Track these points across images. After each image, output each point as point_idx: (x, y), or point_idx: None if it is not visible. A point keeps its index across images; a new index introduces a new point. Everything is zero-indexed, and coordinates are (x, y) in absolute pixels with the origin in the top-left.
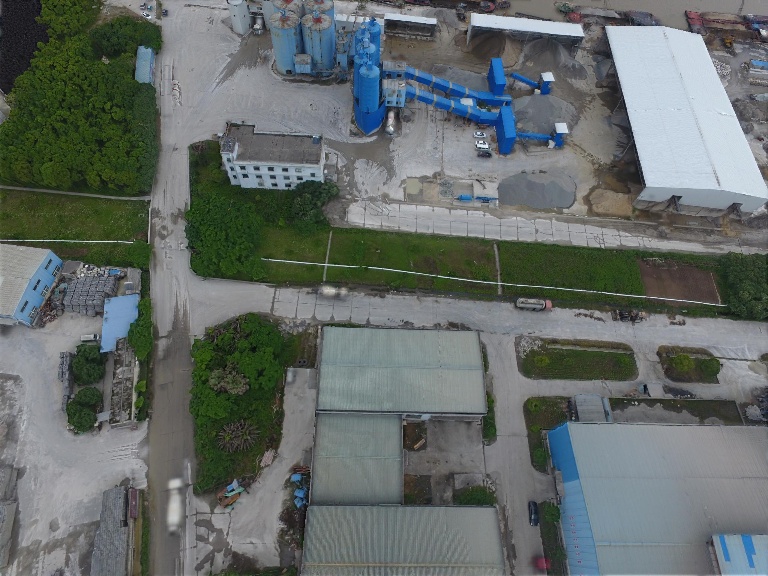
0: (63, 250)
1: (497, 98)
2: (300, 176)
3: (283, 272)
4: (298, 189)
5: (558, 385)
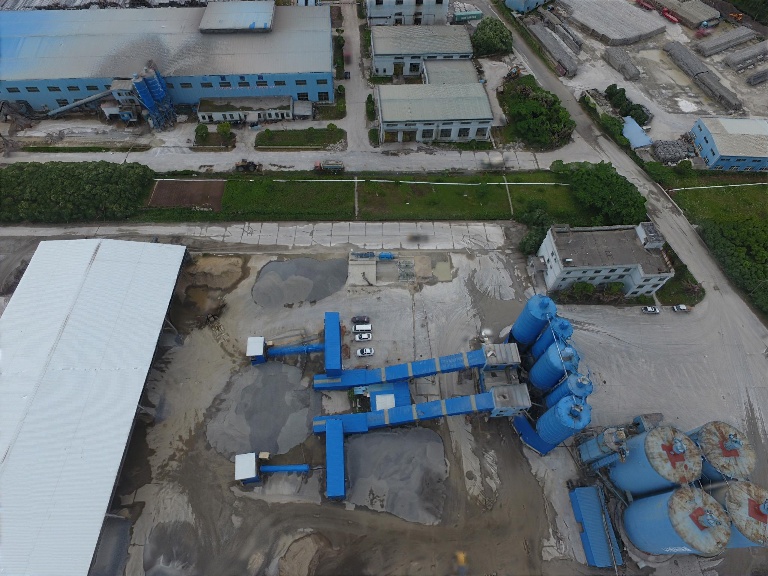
0: (719, 180)
1: None
2: None
3: (539, 176)
4: None
5: (320, 126)
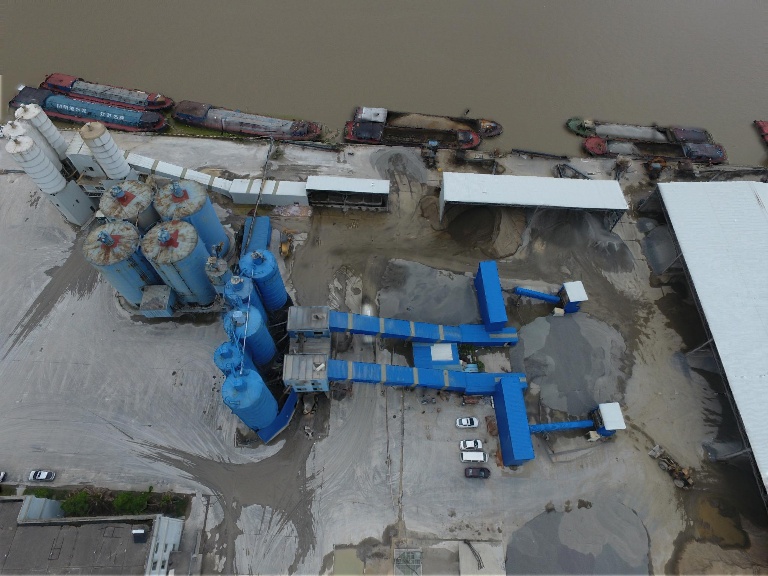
0: None
1: (493, 338)
2: None
3: None
4: None
5: None
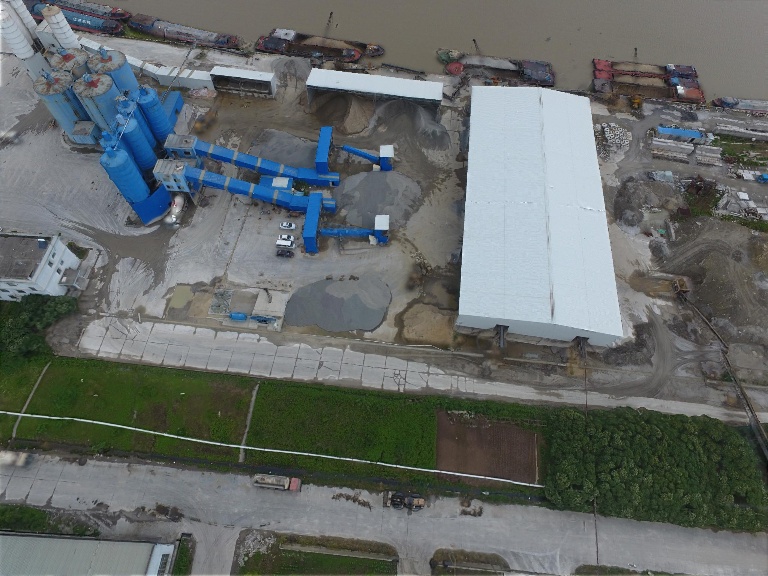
0: None
1: (320, 177)
2: (19, 289)
3: None
4: (22, 303)
5: None
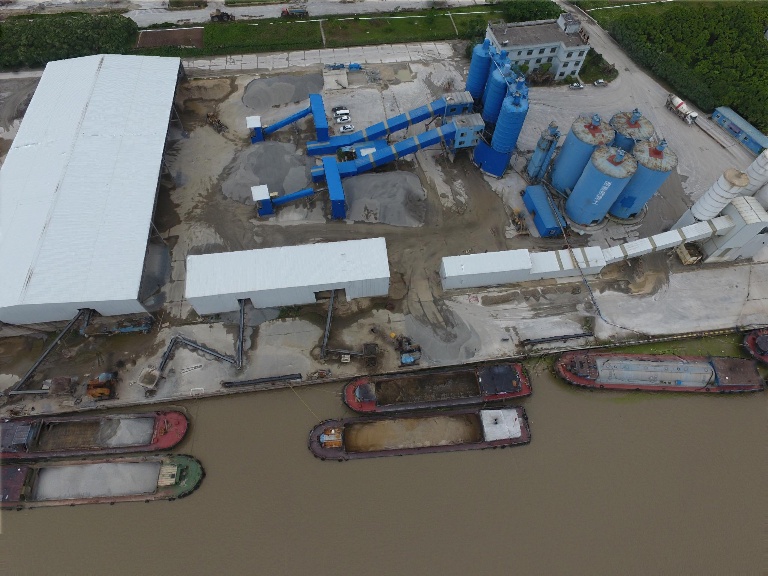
0: (625, 2)
1: None
2: None
3: (477, 8)
4: None
5: None
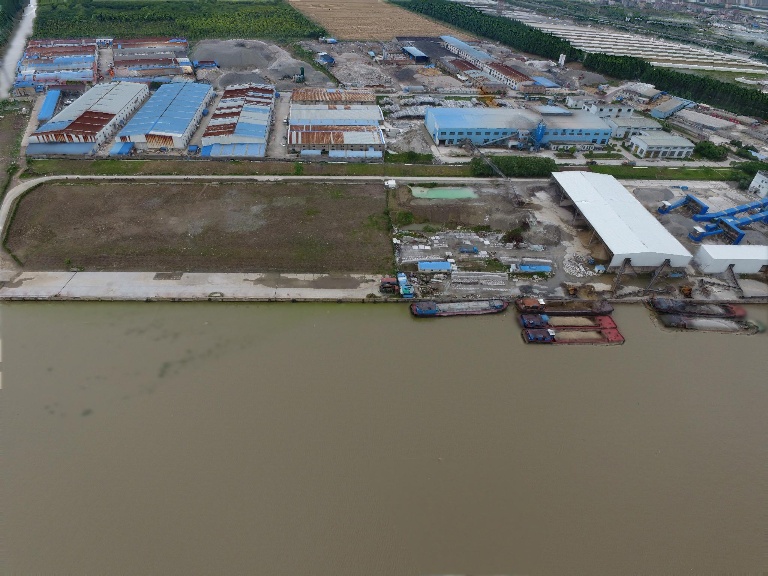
0: None
1: None
2: None
3: None
4: None
5: None
